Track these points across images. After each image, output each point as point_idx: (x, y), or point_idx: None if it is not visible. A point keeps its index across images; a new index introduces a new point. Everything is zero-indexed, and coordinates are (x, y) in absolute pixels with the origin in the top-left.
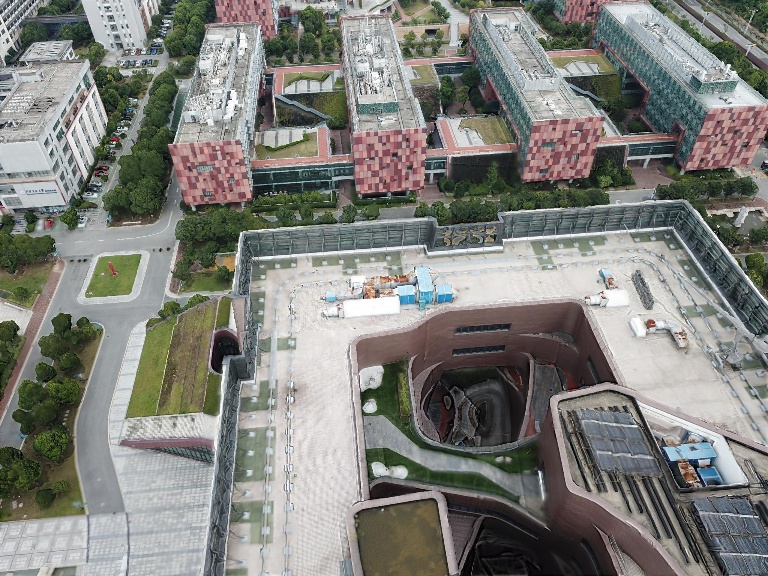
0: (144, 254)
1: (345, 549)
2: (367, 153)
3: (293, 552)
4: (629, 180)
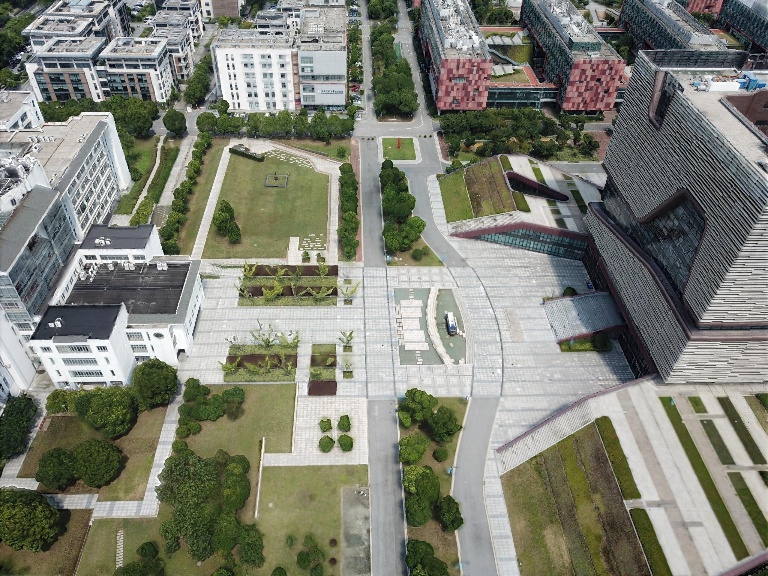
0: (414, 138)
1: (766, 154)
2: (579, 77)
3: (742, 154)
4: None
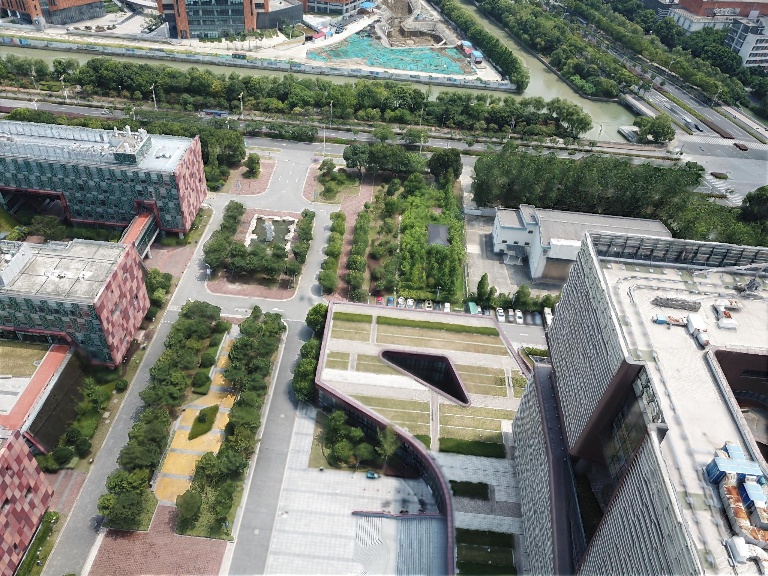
0: None
1: None
2: None
3: None
4: (170, 277)
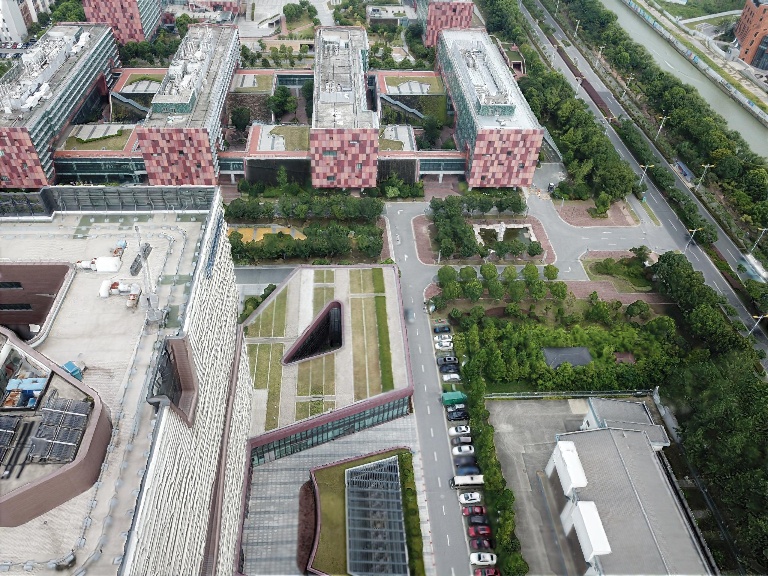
0: None
1: None
2: (153, 149)
3: None
4: (416, 192)
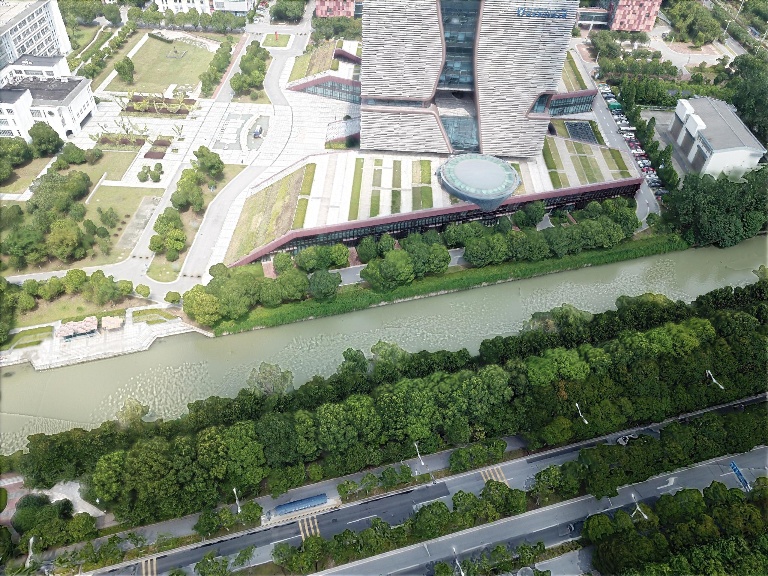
0: (292, 35)
1: None
2: None
3: None
4: (577, 32)
